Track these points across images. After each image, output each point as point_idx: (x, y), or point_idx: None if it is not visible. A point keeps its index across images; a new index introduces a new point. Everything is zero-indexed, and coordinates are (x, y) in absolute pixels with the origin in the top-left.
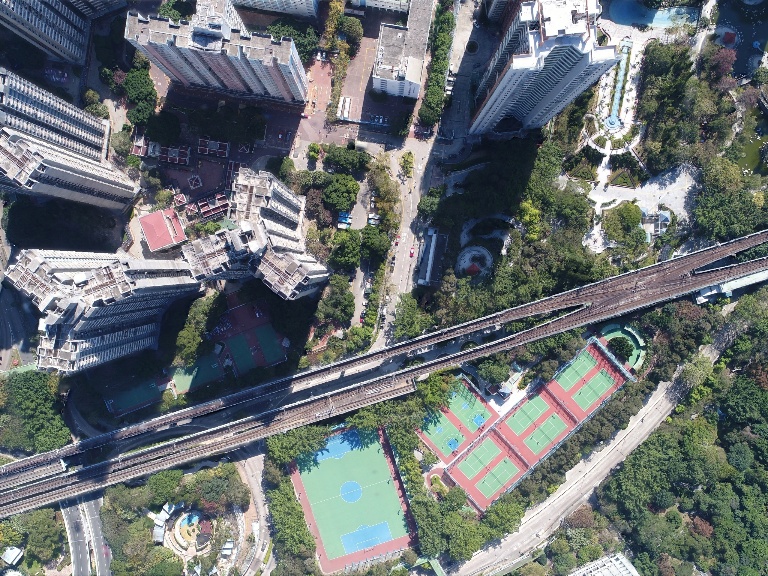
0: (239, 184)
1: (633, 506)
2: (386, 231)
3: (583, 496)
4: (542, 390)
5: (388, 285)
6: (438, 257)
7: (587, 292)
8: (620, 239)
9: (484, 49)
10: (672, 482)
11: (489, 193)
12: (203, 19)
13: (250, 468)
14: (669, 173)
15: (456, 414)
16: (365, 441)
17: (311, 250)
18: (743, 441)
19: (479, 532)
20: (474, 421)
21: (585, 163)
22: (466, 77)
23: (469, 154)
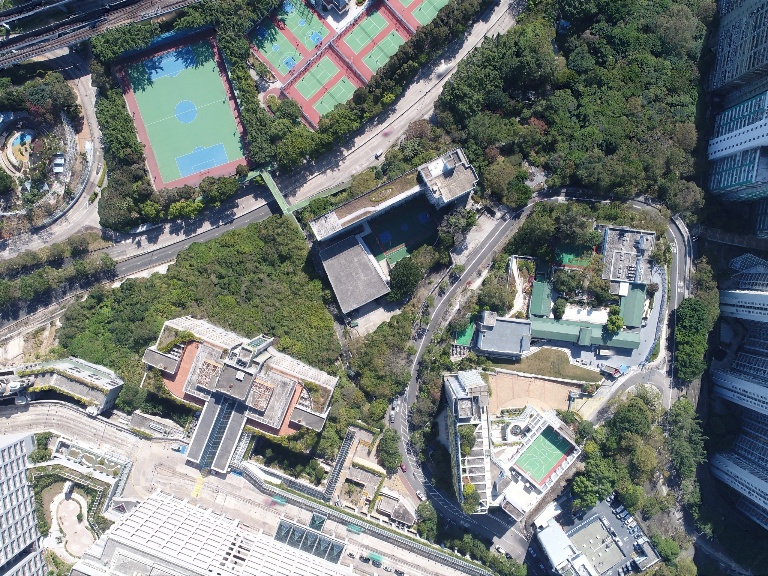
0: None
1: (466, 108)
2: None
3: (423, 116)
4: (381, 6)
5: None
6: None
7: None
8: None
9: None
10: (505, 79)
11: None
12: None
13: (83, 87)
14: None
15: (293, 31)
16: (200, 59)
17: None
18: (582, 44)
19: (308, 136)
20: (311, 38)
21: None
22: None
23: None
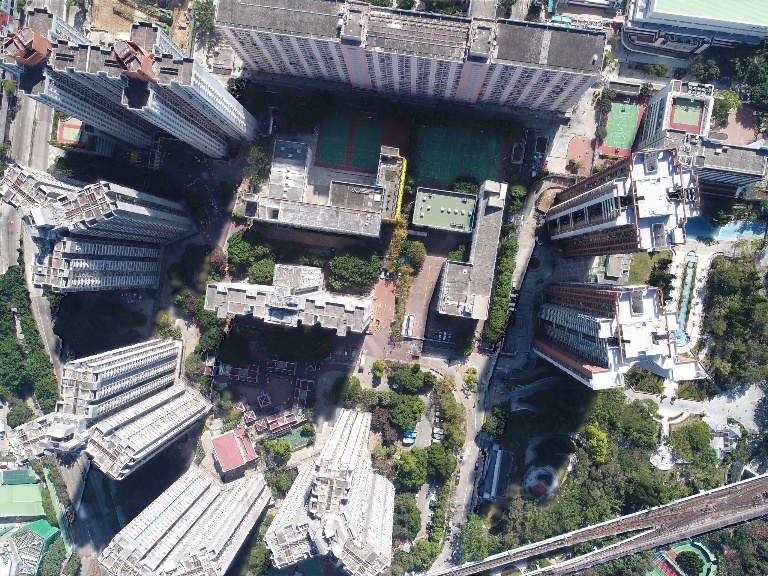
0: (320, 477)
1: None
2: (451, 448)
3: None
4: None
5: (453, 498)
6: (503, 473)
7: (656, 514)
8: (689, 458)
9: (546, 265)
10: None
11: (555, 416)
12: (280, 299)
13: None
14: (738, 386)
15: None
16: None
17: (378, 468)
18: None
19: None
20: None
21: (651, 377)
22: (529, 293)
23: (533, 369)
